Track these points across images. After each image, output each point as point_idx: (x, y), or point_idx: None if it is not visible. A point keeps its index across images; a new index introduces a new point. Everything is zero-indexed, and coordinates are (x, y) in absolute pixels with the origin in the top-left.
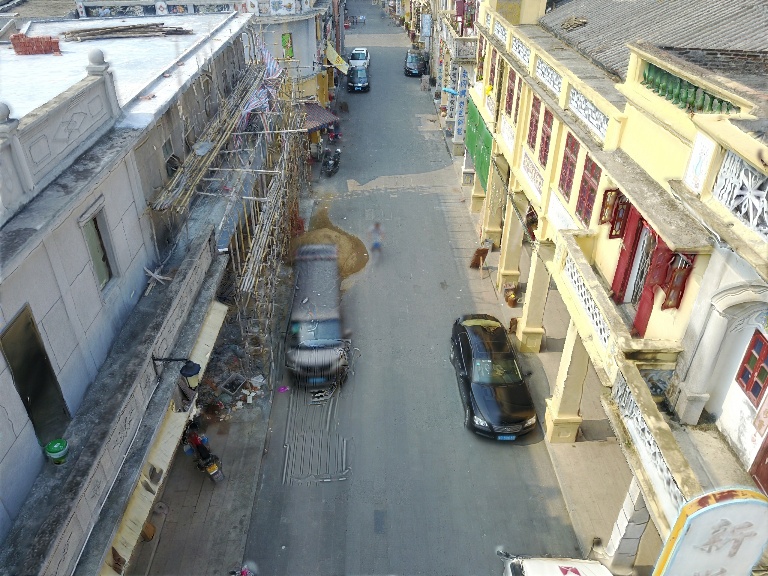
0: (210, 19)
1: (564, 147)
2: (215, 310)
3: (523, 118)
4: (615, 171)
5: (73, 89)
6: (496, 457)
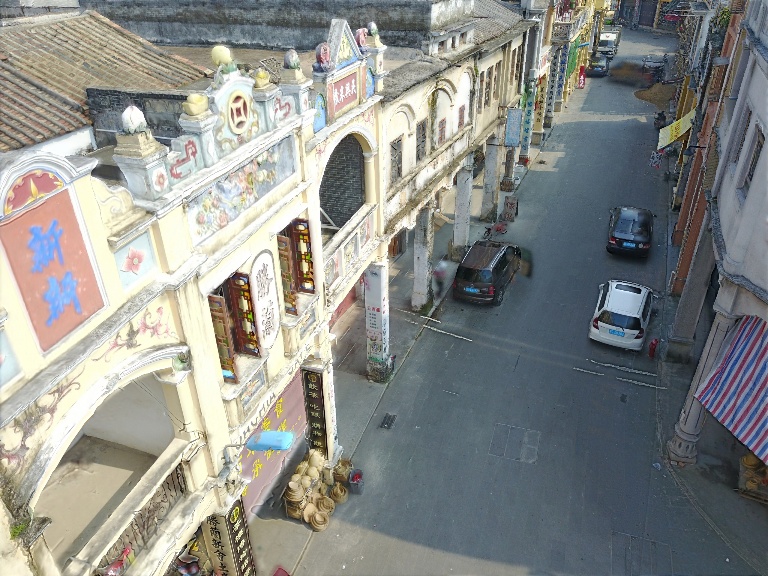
0: None
1: None
2: None
3: None
4: None
5: None
6: None
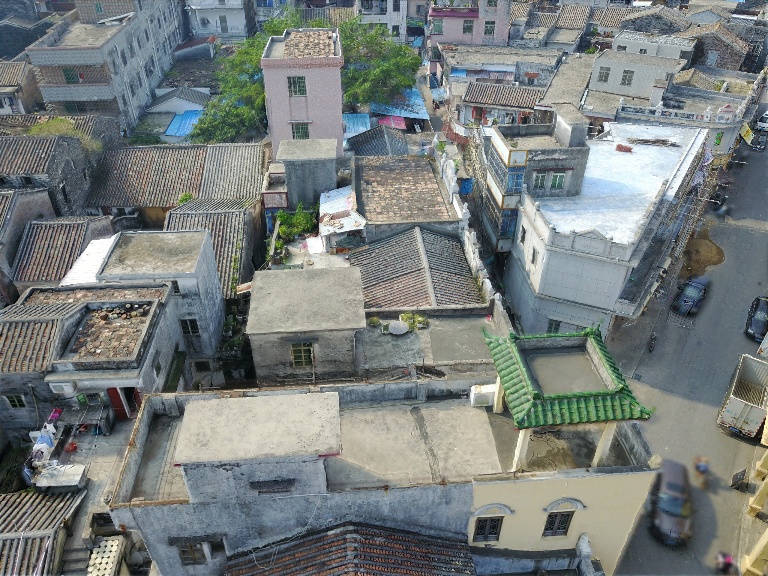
0: (687, 133)
1: None
2: (668, 259)
3: None
4: None
5: None
6: (752, 345)
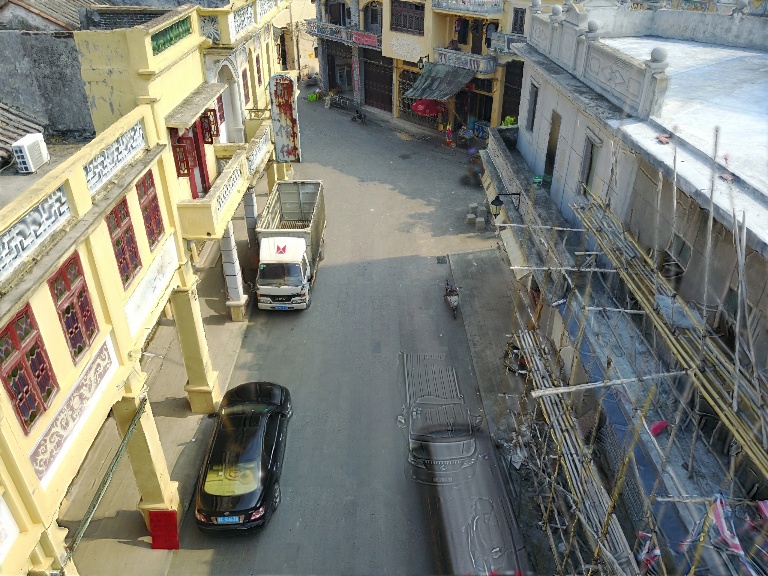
0: None
1: (110, 241)
2: None
3: (9, 413)
4: (196, 110)
5: (631, 58)
6: None
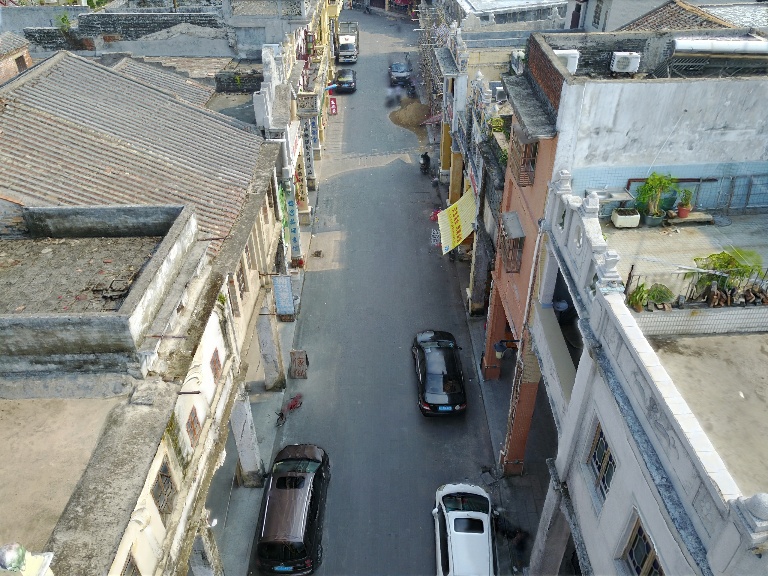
0: None
1: None
2: None
3: None
4: None
5: None
6: None
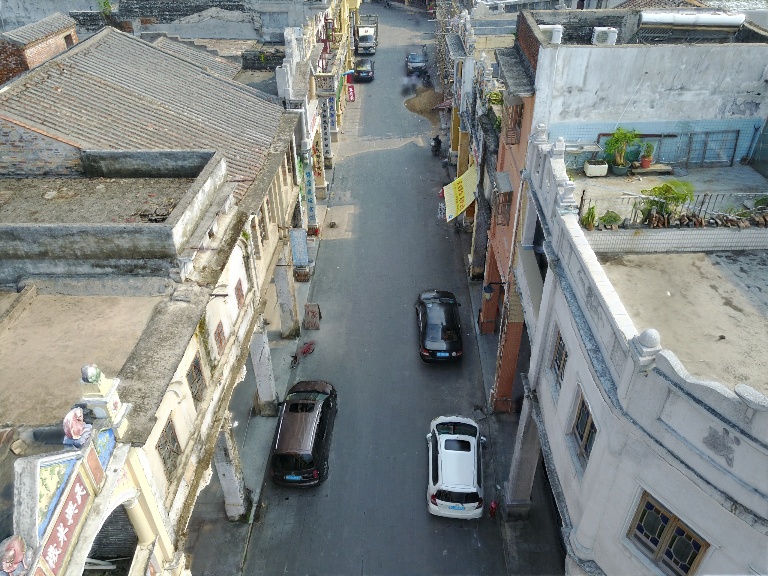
0: None
1: None
2: None
3: None
4: None
5: None
6: None
